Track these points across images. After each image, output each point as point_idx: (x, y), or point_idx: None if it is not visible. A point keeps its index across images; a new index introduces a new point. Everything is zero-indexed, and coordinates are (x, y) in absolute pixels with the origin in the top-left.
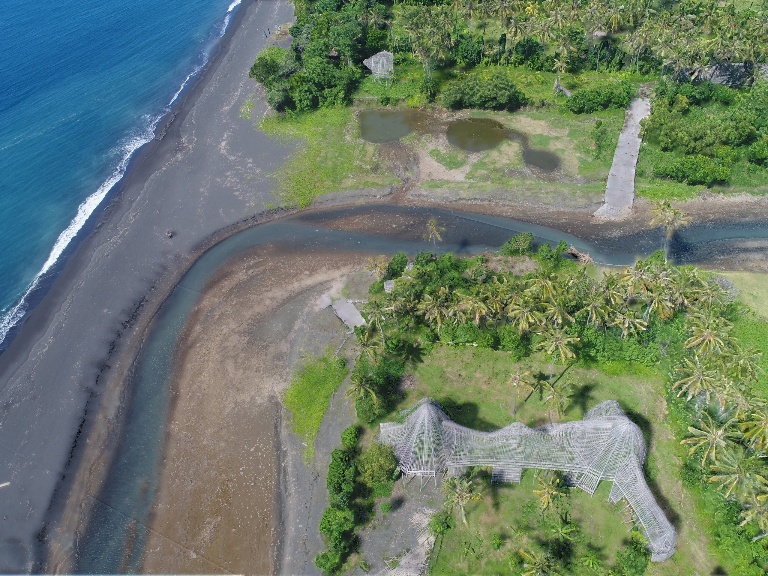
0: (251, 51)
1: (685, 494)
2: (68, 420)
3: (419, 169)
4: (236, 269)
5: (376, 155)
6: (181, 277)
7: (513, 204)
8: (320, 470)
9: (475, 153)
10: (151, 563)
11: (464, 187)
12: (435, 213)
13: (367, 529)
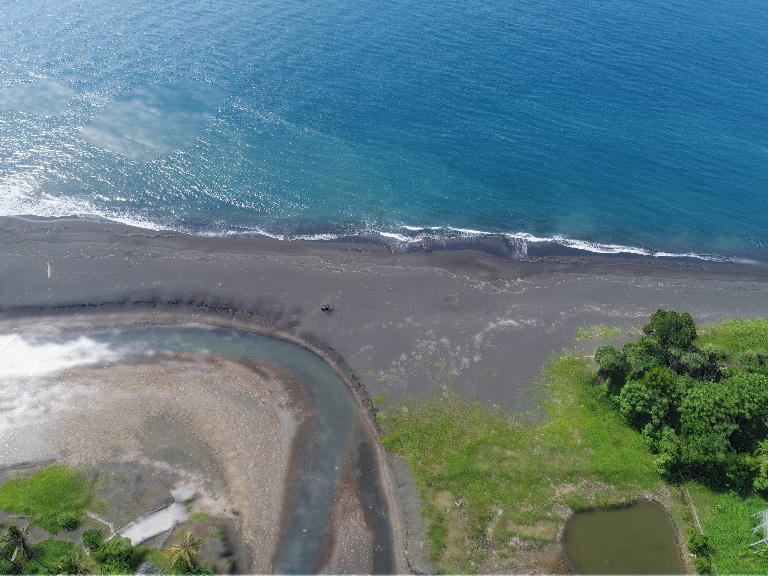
0: None
1: None
2: (96, 294)
3: None
4: (273, 384)
5: (524, 542)
6: (268, 335)
7: None
8: None
9: None
10: None
11: None
12: None
13: None
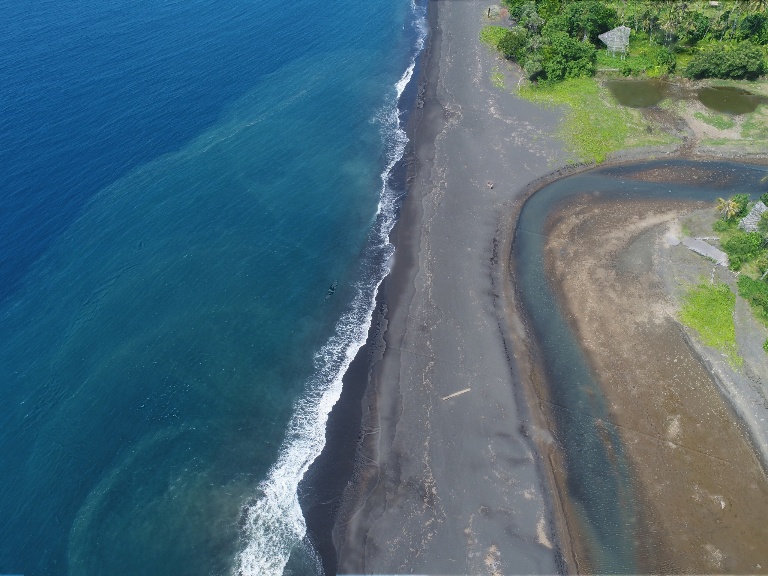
0: (469, 30)
1: None
2: (492, 338)
3: (692, 130)
4: (565, 215)
5: (643, 118)
6: (516, 222)
7: None
8: (759, 374)
9: (738, 116)
10: (637, 452)
11: (746, 144)
12: (728, 166)
13: None
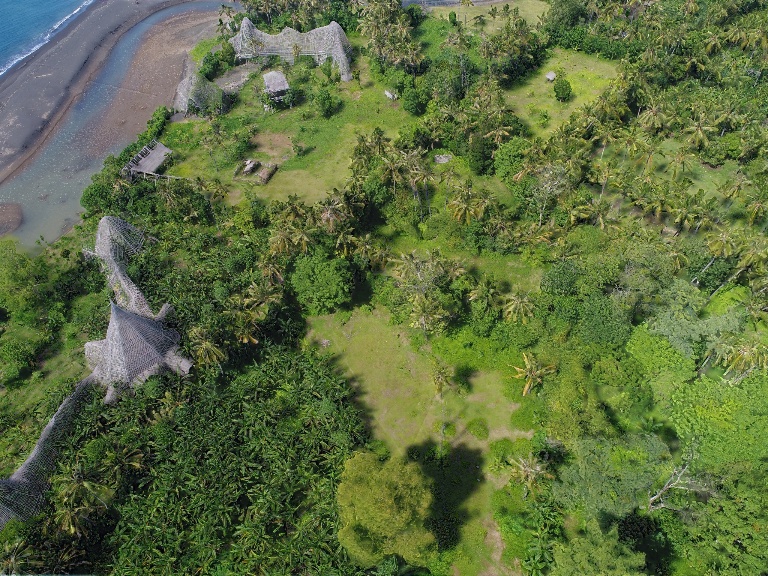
0: None
1: (368, 66)
2: (80, 58)
3: None
4: (173, 16)
5: None
6: (142, 19)
7: None
8: None
9: None
10: (119, 95)
11: None
12: None
13: (219, 78)
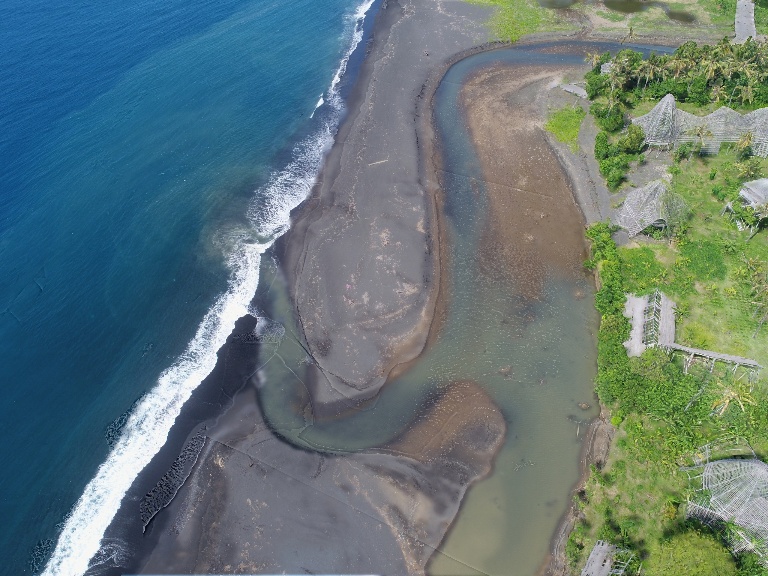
0: None
1: None
2: (408, 136)
3: (591, 22)
4: (480, 73)
5: (556, 15)
6: (442, 77)
7: (668, 39)
8: (587, 152)
9: (630, 13)
10: (494, 193)
11: None
12: (612, 45)
13: (628, 173)
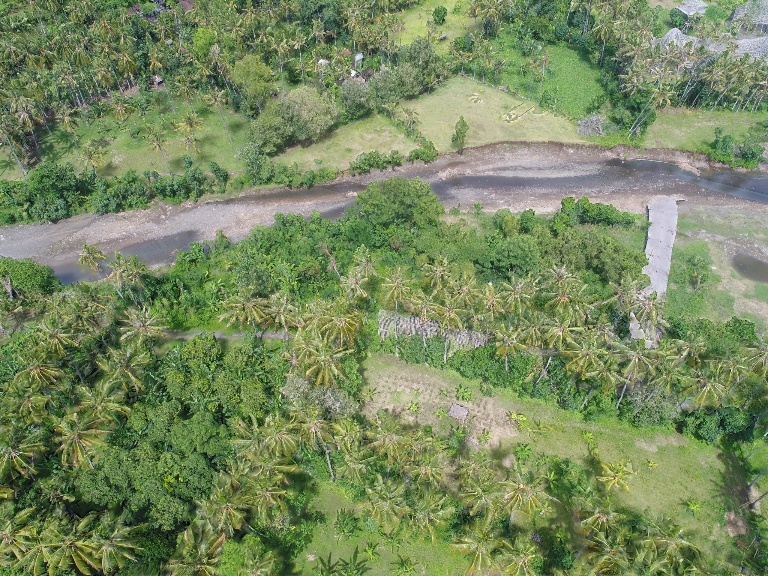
0: None
1: None
2: None
3: None
4: None
5: None
6: None
7: None
8: None
9: None
10: None
11: None
12: None
13: None
